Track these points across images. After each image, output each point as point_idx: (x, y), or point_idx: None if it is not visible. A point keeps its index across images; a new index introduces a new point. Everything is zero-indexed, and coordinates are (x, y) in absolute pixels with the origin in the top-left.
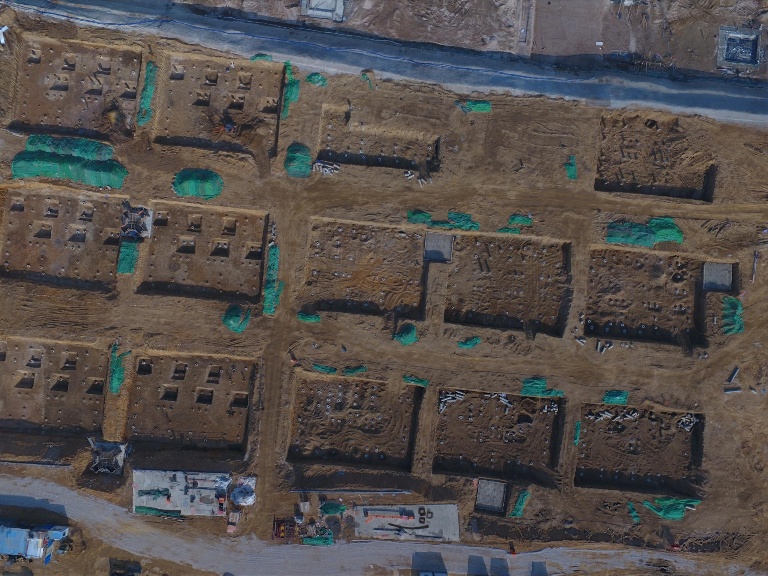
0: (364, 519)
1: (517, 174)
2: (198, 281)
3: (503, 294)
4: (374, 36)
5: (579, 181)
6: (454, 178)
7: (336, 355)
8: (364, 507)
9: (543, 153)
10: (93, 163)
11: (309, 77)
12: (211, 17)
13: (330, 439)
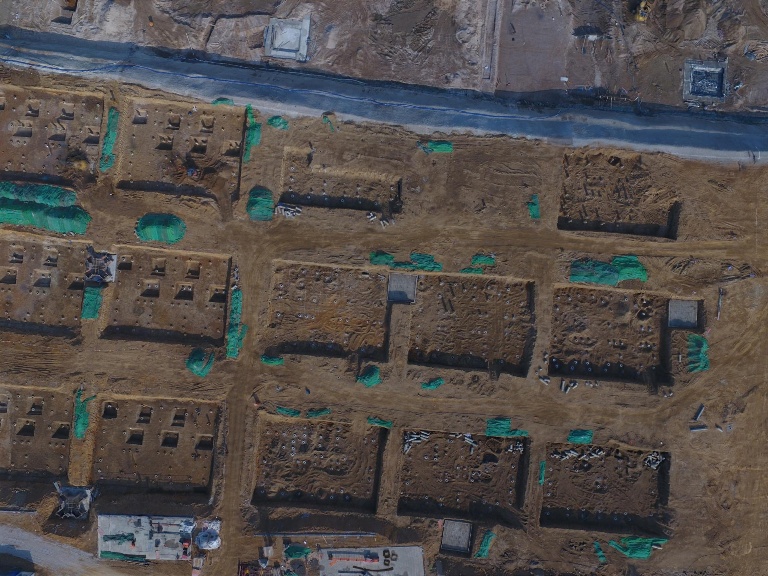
0: (329, 562)
1: (479, 214)
2: (162, 324)
3: (467, 334)
4: (338, 75)
5: (542, 220)
6: (416, 219)
7: (300, 397)
8: (329, 550)
9: (505, 193)
10: (56, 209)
11: (270, 120)
12: (175, 59)
13: (295, 481)
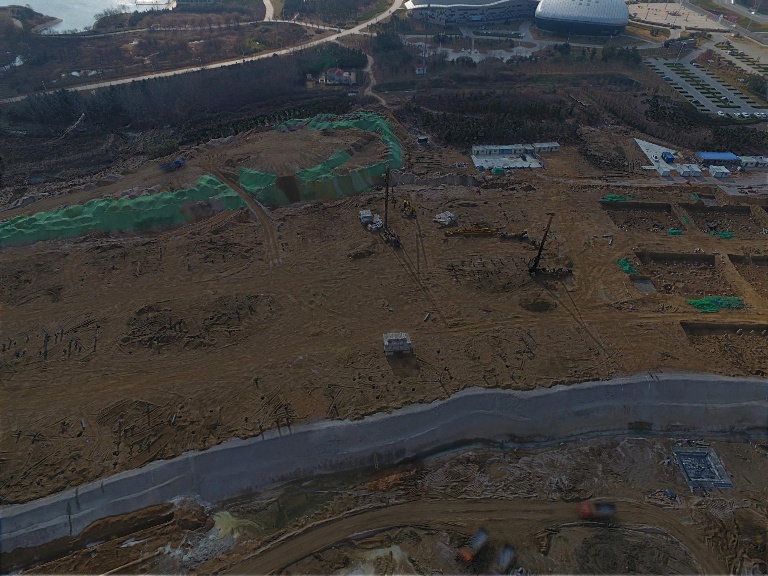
0: None
1: None
2: None
3: None
4: None
5: None
6: None
7: None
8: None
9: None
10: None
11: None
12: None
13: None
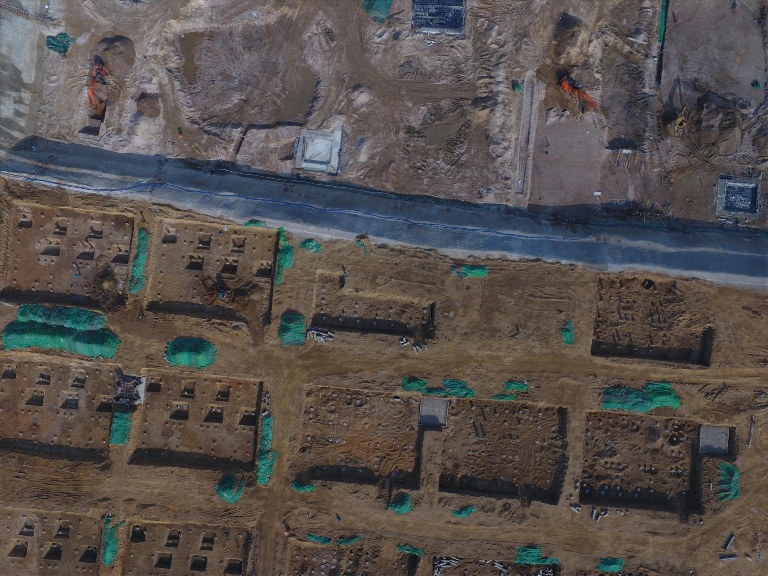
0: None
1: (513, 340)
2: (191, 448)
3: (498, 458)
4: (369, 189)
5: (575, 346)
6: (449, 345)
7: (330, 524)
8: None
9: (539, 318)
10: (85, 334)
11: (303, 243)
12: (204, 171)
13: None
